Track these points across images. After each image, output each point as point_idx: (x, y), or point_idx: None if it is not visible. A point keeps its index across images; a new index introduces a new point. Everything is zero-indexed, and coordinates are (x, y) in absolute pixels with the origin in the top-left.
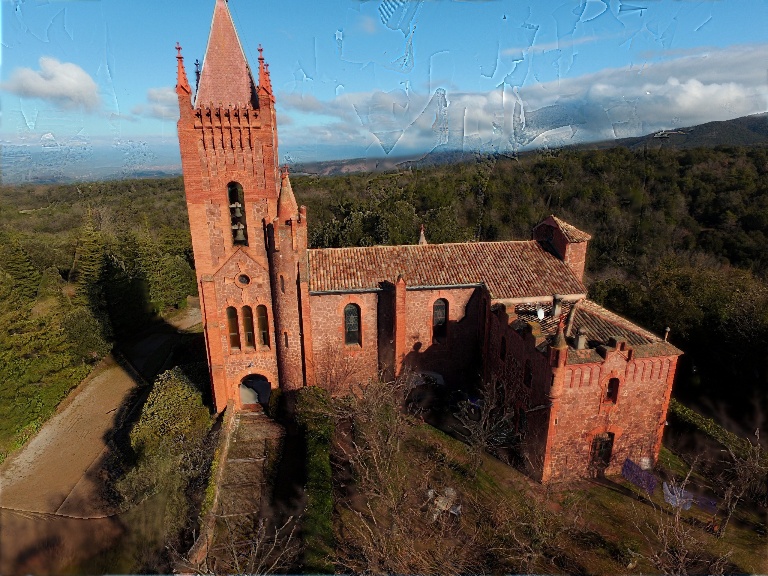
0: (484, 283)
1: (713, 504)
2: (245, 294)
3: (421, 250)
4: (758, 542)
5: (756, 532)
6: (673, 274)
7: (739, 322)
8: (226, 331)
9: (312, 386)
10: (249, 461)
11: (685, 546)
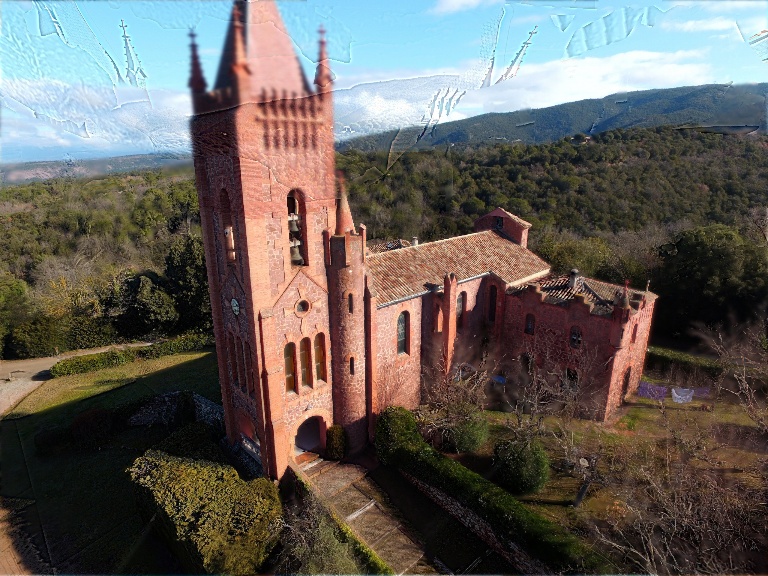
0: (492, 271)
1: (708, 391)
2: (305, 324)
3: (427, 249)
4: (726, 407)
5: (719, 402)
6: (561, 247)
7: (622, 273)
8: (284, 374)
9: (390, 407)
10: (361, 513)
11: (707, 424)
